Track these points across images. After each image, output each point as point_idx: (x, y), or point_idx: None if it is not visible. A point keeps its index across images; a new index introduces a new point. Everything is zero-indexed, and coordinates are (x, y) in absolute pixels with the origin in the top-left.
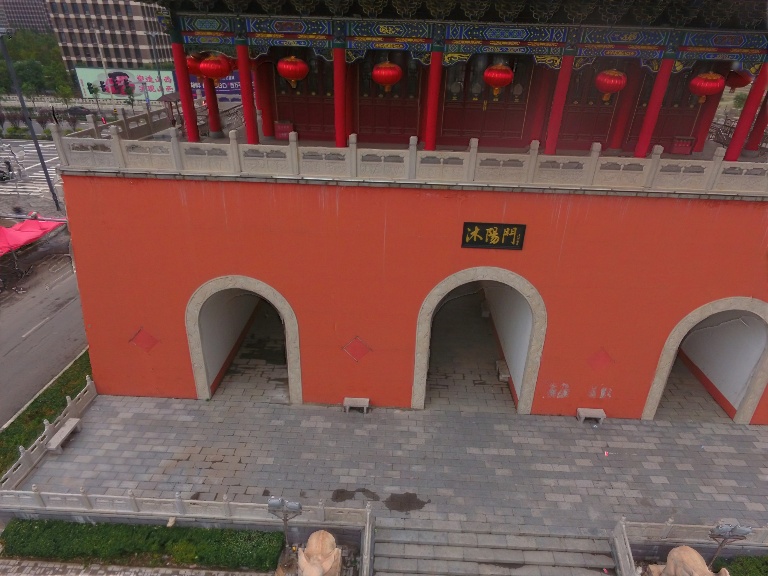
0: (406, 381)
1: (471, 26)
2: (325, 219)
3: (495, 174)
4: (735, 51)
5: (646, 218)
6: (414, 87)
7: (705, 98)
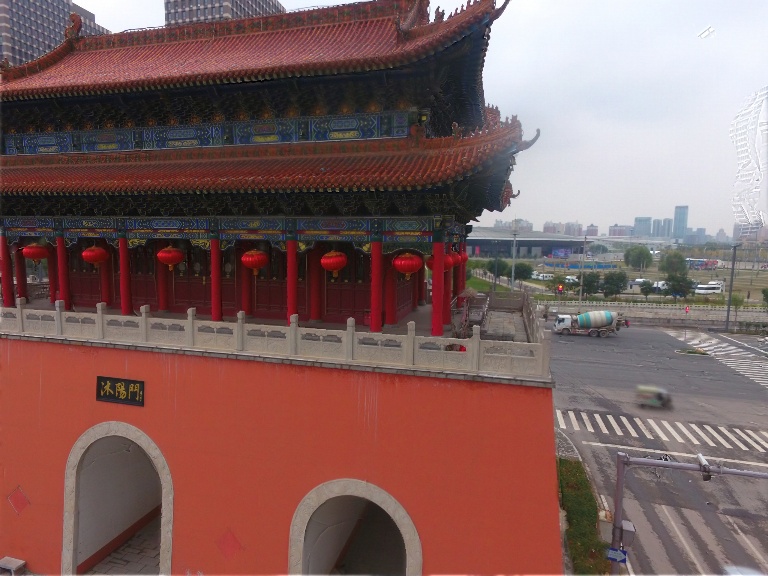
0: (57, 544)
1: (141, 219)
2: (1, 367)
3: (119, 333)
4: (344, 233)
5: (243, 381)
6: (152, 266)
7: (336, 273)
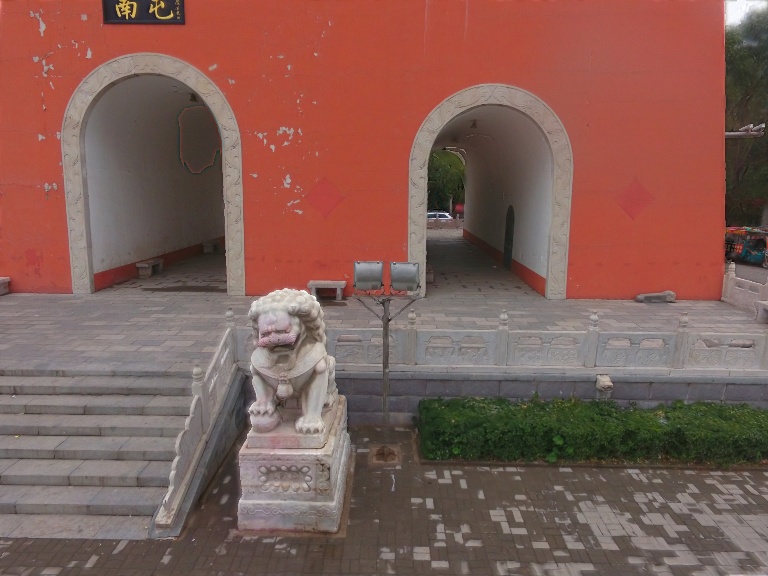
0: None
1: None
2: None
3: None
4: None
5: None
6: None
7: None
